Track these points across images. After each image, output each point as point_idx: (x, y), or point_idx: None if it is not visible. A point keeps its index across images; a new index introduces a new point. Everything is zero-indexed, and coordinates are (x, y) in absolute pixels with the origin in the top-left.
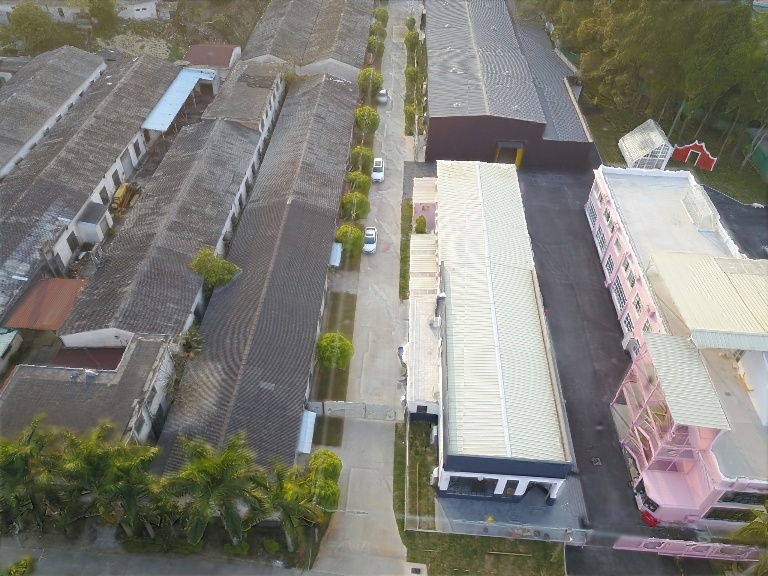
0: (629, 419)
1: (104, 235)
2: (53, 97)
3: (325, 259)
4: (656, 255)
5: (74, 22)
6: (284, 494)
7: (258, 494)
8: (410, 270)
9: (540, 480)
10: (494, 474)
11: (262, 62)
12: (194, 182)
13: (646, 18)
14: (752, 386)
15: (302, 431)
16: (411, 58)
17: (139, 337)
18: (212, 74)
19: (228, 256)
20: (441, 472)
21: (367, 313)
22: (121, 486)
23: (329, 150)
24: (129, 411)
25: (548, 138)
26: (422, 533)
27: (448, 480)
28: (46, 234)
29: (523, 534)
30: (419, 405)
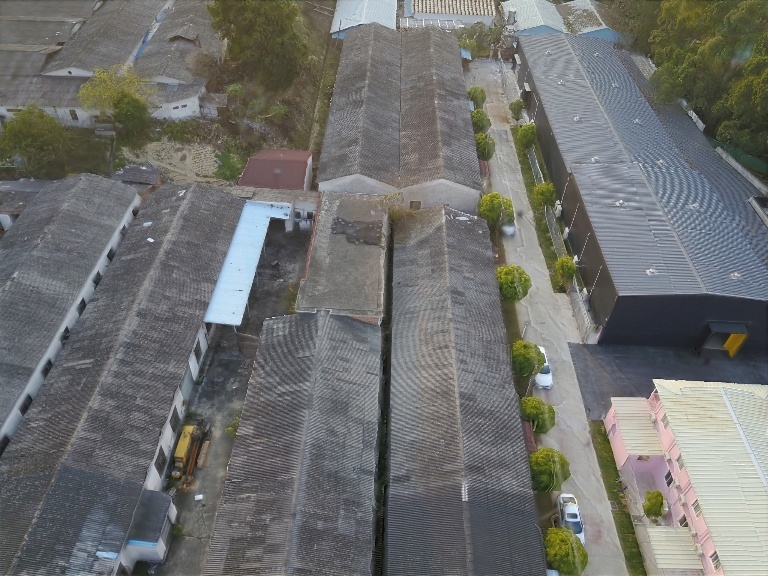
0: None
1: (166, 544)
2: (72, 271)
3: None
4: None
5: (91, 127)
6: None
7: None
8: None
9: None
10: None
11: (357, 194)
12: (310, 462)
13: None
14: None
15: None
16: (523, 156)
17: None
18: (286, 208)
19: None
20: None
21: None
22: None
23: (486, 358)
24: None
25: None
26: None
27: None
28: None
29: None
30: None
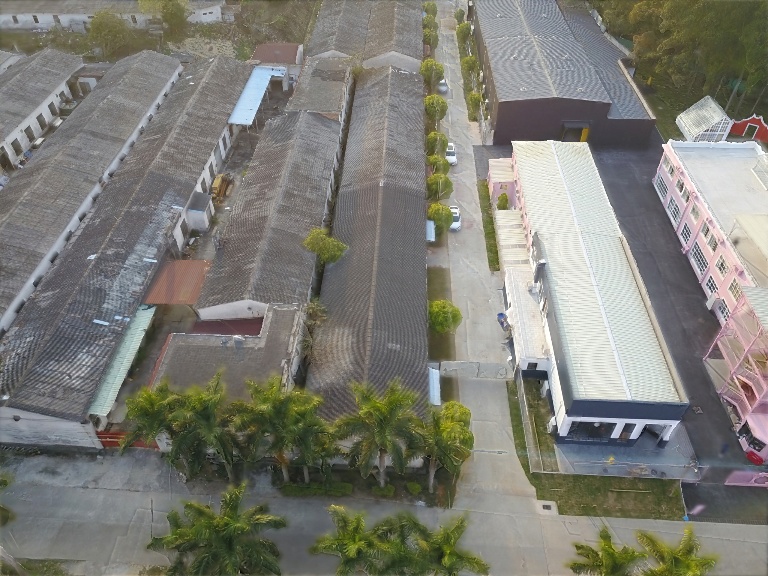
0: (723, 372)
1: (209, 222)
2: (143, 98)
3: (422, 235)
4: (741, 218)
5: (146, 28)
6: (442, 432)
7: (421, 431)
8: (500, 243)
9: (656, 423)
10: (613, 418)
11: (330, 57)
12: (291, 169)
13: None
14: None
15: (430, 386)
16: (463, 49)
17: (274, 306)
18: (283, 71)
19: (332, 235)
20: (563, 418)
21: (462, 284)
22: (301, 427)
23: (407, 136)
24: (280, 370)
25: (612, 117)
26: (548, 475)
27: (569, 426)
28: (165, 221)
29: (641, 473)
30: (530, 362)
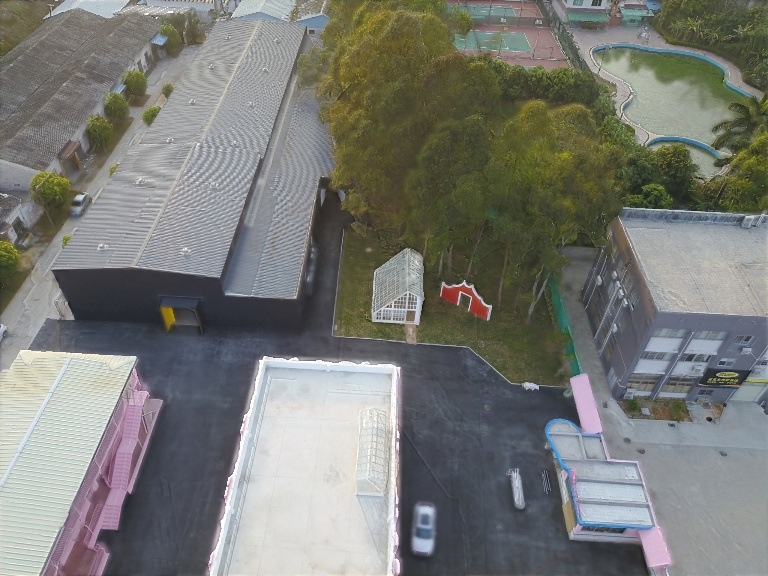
0: None
1: None
2: None
3: None
4: None
5: None
6: None
7: None
8: None
9: None
10: None
11: None
12: None
13: (364, 124)
14: None
15: None
16: None
17: None
18: None
19: None
20: None
21: None
22: None
23: None
24: None
25: (234, 292)
26: None
27: None
28: None
29: None
30: None
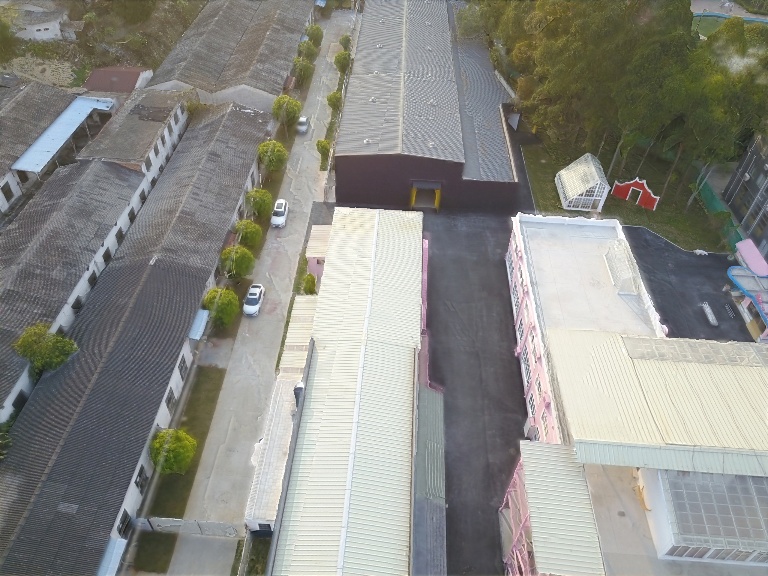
0: None
1: None
2: None
3: (182, 332)
4: (554, 334)
5: None
6: None
7: None
8: (285, 342)
9: None
10: None
11: (163, 90)
12: (45, 239)
13: (576, 45)
14: (650, 505)
15: (103, 567)
16: (343, 80)
17: None
18: (109, 103)
19: (70, 329)
20: None
21: (234, 393)
22: None
23: (218, 194)
24: None
25: (469, 177)
26: None
27: None
28: None
29: None
30: (260, 523)
